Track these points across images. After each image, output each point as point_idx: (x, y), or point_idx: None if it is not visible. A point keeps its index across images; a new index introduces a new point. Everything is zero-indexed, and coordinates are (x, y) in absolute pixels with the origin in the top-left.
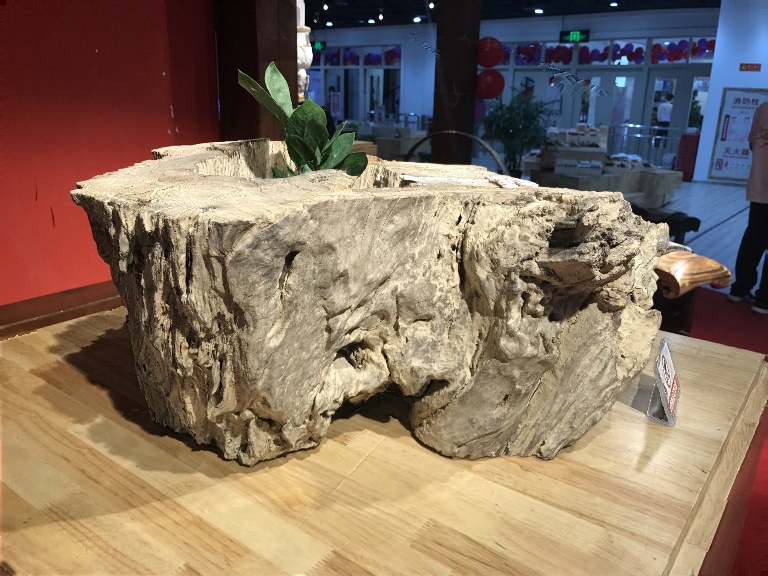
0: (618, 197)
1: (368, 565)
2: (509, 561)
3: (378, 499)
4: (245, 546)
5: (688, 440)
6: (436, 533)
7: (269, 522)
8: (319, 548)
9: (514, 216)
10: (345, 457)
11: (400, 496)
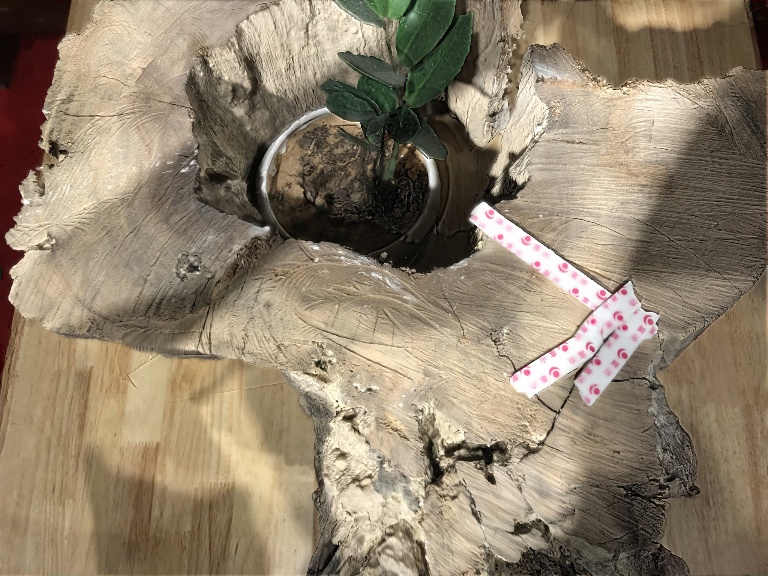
0: None
1: (159, 474)
2: (224, 563)
3: (231, 431)
4: (127, 386)
5: None
6: (220, 497)
7: (156, 381)
8: (154, 432)
9: (352, 477)
10: (267, 368)
11: (245, 444)
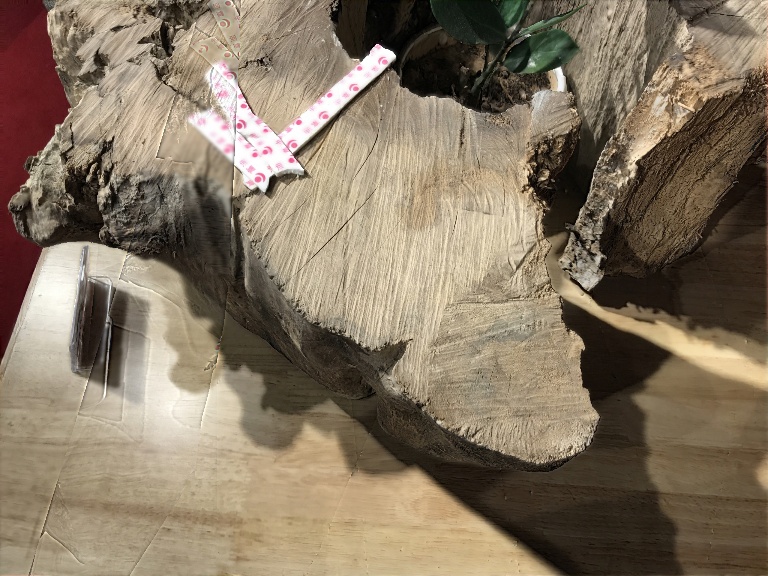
0: (57, 4)
1: None
2: None
3: None
4: None
5: (73, 258)
6: None
7: None
8: None
9: None
10: None
11: None
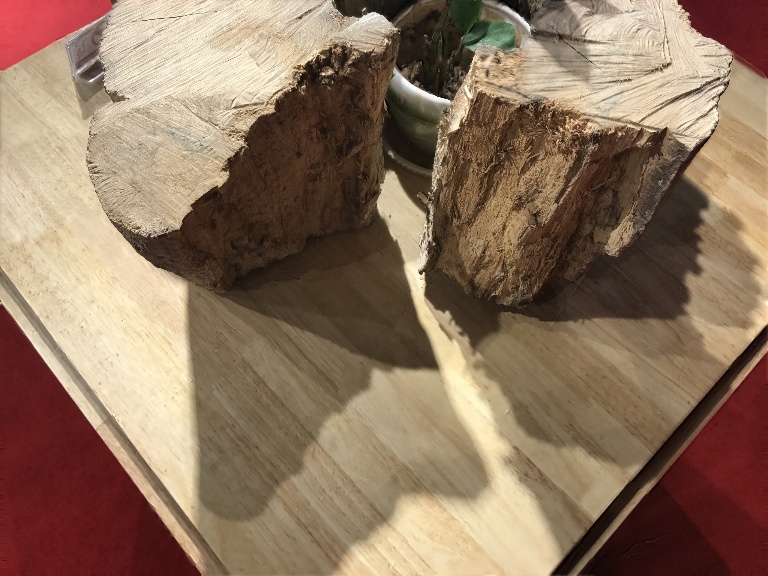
0: None
1: None
2: None
3: None
4: None
5: None
6: None
7: None
8: None
9: None
10: None
11: None
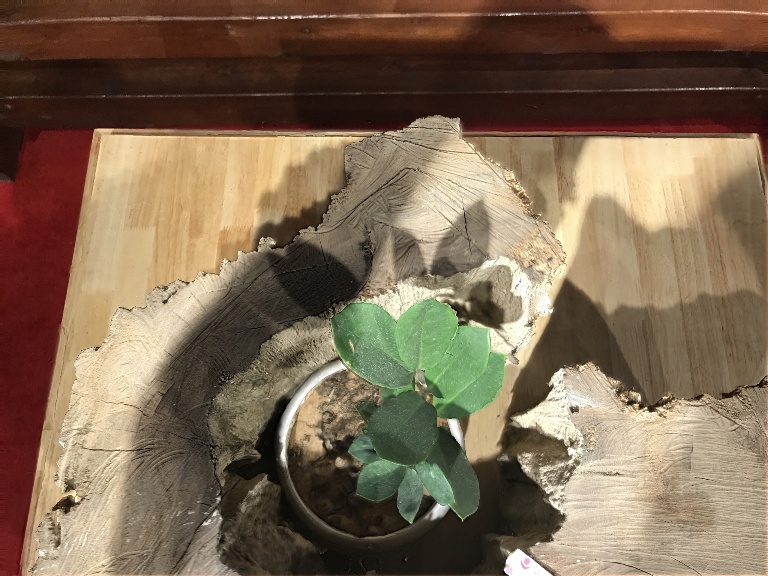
0: None
1: None
2: None
3: None
4: None
5: None
6: None
7: None
8: None
9: None
10: None
11: None
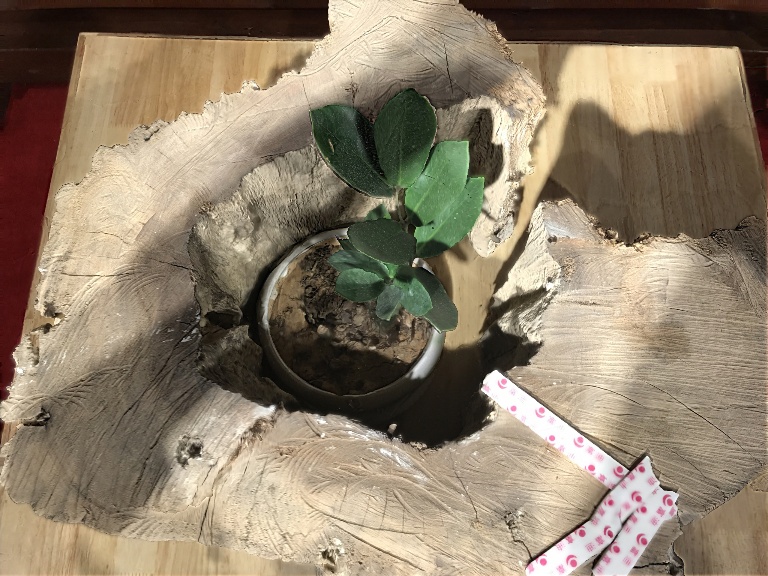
0: None
1: None
2: None
3: (228, 562)
4: None
5: None
6: None
7: None
8: (148, 563)
9: None
10: None
11: (243, 575)
